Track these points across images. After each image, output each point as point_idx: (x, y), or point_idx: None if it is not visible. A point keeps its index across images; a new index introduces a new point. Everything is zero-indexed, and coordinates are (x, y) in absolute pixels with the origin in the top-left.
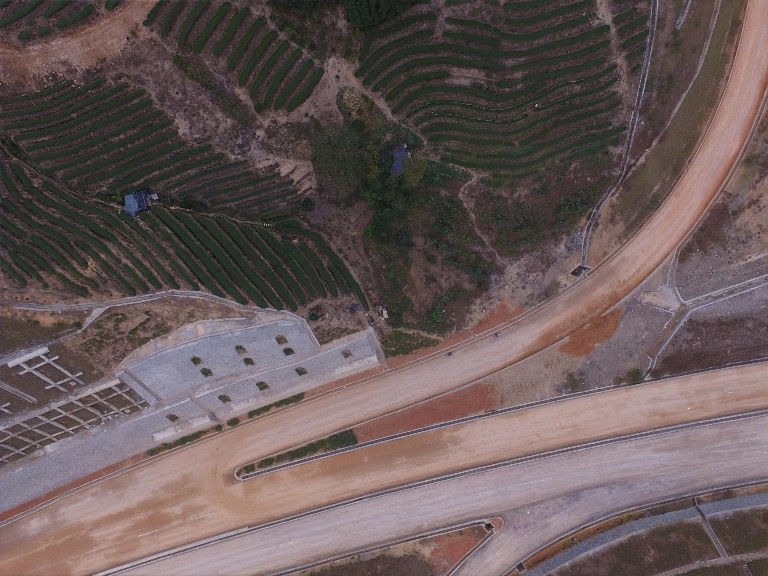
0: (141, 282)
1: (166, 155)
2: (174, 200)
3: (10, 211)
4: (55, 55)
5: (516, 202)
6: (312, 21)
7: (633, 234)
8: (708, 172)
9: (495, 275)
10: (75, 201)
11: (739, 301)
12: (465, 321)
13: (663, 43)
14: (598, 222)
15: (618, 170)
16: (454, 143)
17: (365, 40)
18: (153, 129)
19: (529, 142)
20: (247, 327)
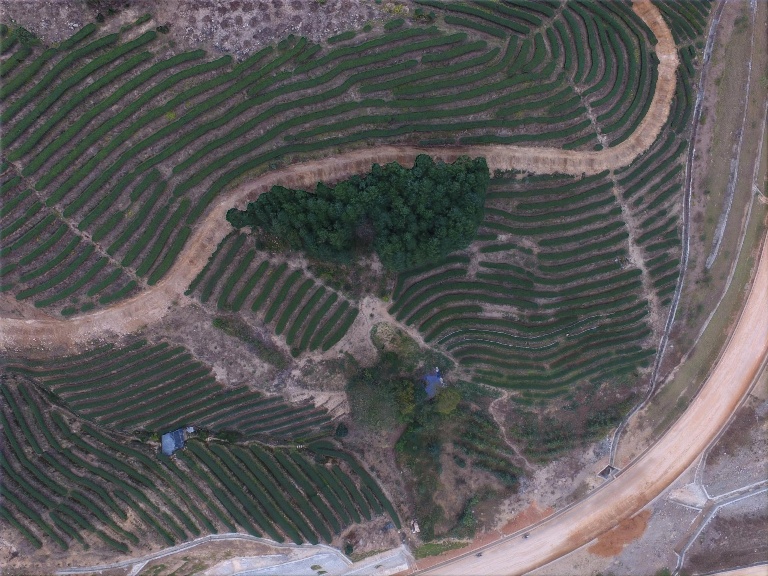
0: (179, 531)
1: (203, 398)
2: (209, 431)
3: (50, 464)
4: (97, 324)
5: (546, 418)
6: (347, 264)
7: (660, 436)
8: (734, 374)
9: (524, 479)
10: (113, 444)
11: (765, 497)
12: (494, 521)
13: (693, 281)
14: (626, 430)
15: (647, 387)
16: (485, 365)
17: (399, 279)
18: (191, 378)
19: (560, 366)
20: (283, 563)
